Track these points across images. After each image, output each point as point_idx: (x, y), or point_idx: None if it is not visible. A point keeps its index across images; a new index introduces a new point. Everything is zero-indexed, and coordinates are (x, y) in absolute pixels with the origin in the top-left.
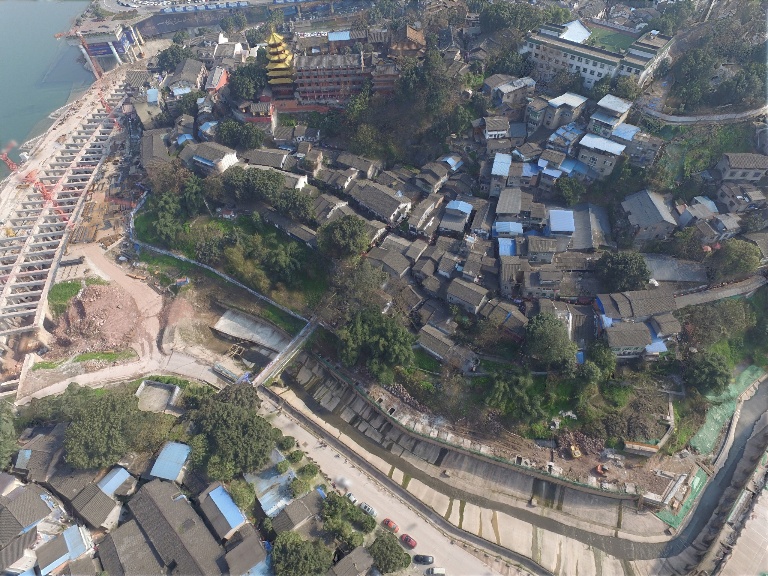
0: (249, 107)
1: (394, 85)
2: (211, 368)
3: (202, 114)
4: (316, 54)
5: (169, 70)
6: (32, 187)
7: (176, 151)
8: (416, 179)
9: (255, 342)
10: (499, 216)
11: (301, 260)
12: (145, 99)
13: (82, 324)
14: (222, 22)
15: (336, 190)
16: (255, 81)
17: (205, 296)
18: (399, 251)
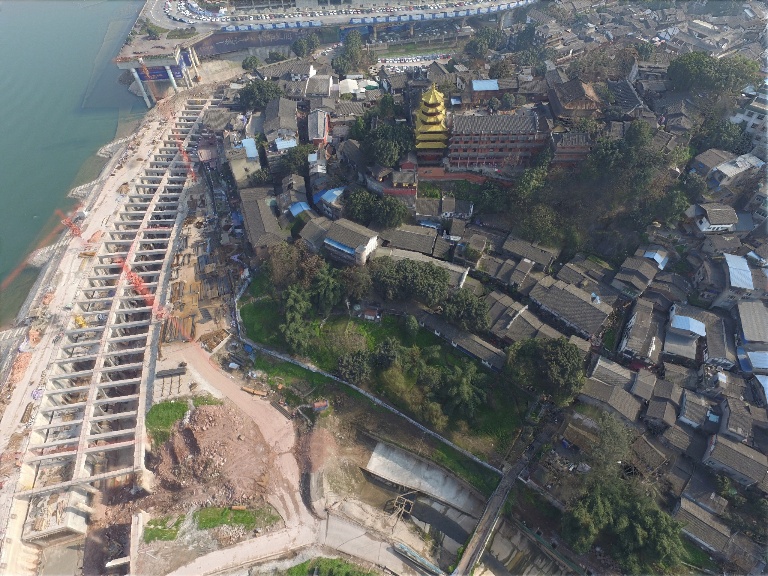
0: (387, 175)
1: (579, 157)
2: (390, 546)
3: (316, 175)
4: (456, 106)
5: (253, 109)
6: (98, 255)
7: (290, 224)
8: (614, 279)
9: (425, 493)
10: (746, 342)
11: (482, 387)
12: (244, 154)
13: (196, 463)
14: (295, 45)
15: (506, 286)
16: (401, 146)
17: (349, 423)
18: (619, 385)
